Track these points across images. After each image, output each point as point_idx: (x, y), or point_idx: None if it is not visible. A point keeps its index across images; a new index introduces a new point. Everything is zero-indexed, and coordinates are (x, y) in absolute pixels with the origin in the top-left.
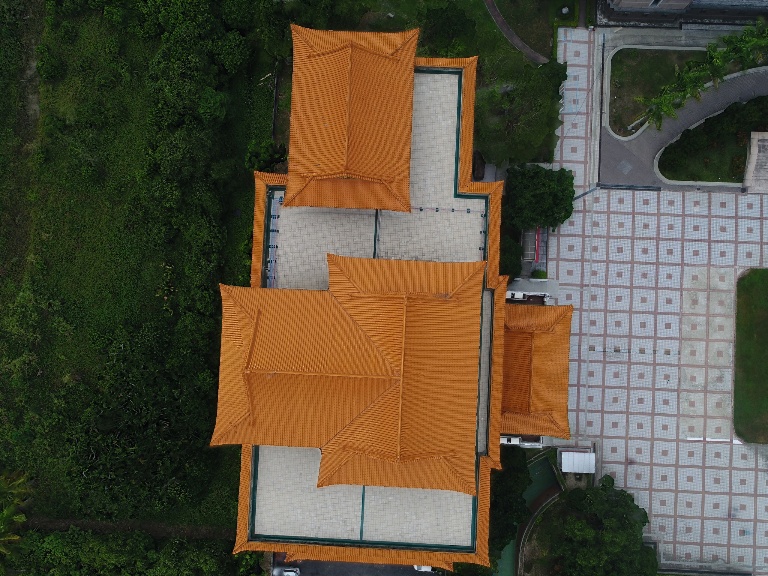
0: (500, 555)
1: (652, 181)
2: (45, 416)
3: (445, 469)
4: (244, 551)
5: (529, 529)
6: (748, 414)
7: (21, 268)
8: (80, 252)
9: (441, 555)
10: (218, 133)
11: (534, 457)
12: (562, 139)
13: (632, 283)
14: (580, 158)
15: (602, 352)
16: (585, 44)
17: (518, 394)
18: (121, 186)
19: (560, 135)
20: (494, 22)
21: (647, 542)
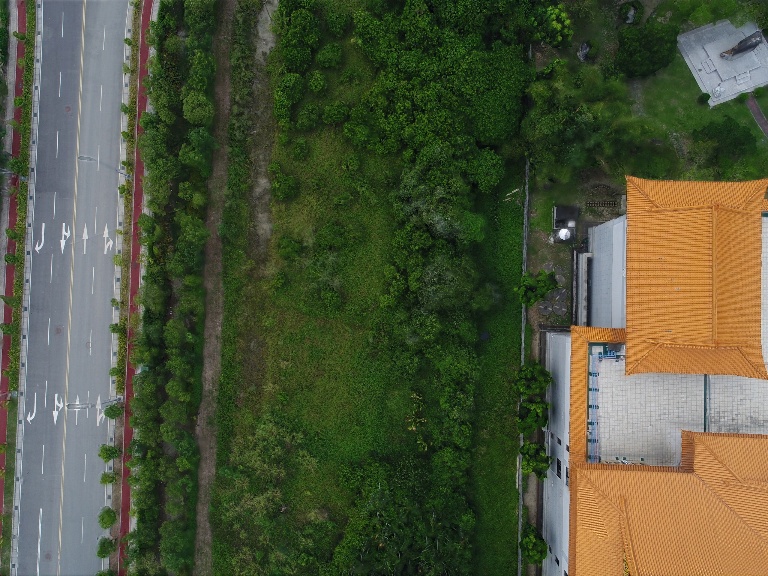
0: None
1: None
2: (292, 556)
3: None
4: None
5: None
6: None
7: (258, 397)
8: (321, 380)
9: None
10: (471, 256)
11: None
12: None
13: None
14: None
15: None
16: None
17: None
18: (362, 310)
19: None
20: (761, 131)
21: None
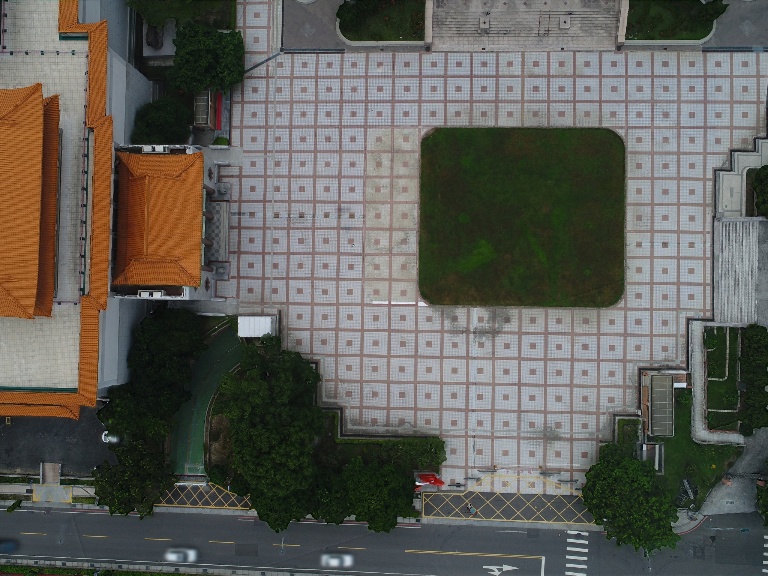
0: (177, 421)
1: (335, 43)
2: None
3: (0, 293)
4: None
5: (214, 398)
6: (433, 275)
7: None
8: None
9: (46, 397)
10: None
11: (218, 325)
12: (245, 5)
13: (316, 147)
14: (263, 23)
15: (286, 218)
16: None
17: (140, 240)
18: None
19: (243, 1)
20: None
21: (334, 408)
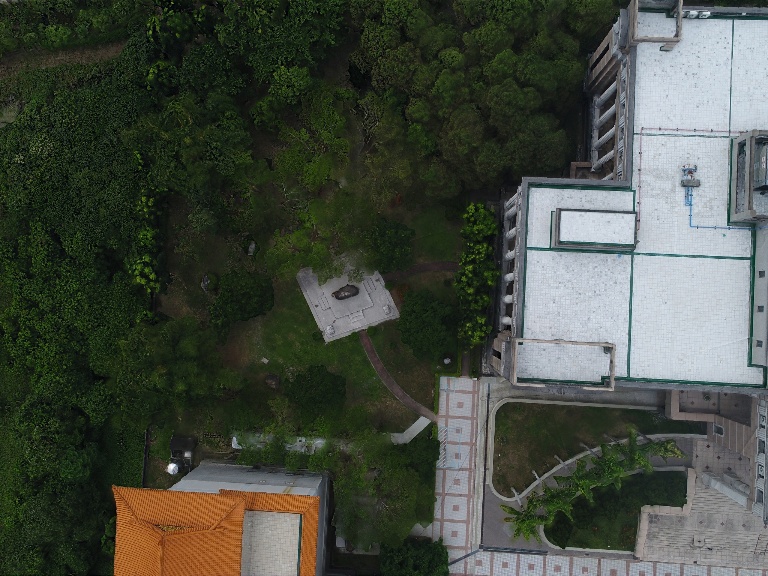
0: None
1: (538, 545)
2: None
3: None
4: None
5: None
6: None
7: None
8: None
9: None
10: (85, 486)
11: None
12: (443, 496)
13: None
14: (462, 517)
15: None
16: (469, 394)
17: None
18: None
19: (441, 492)
20: (373, 369)
21: None
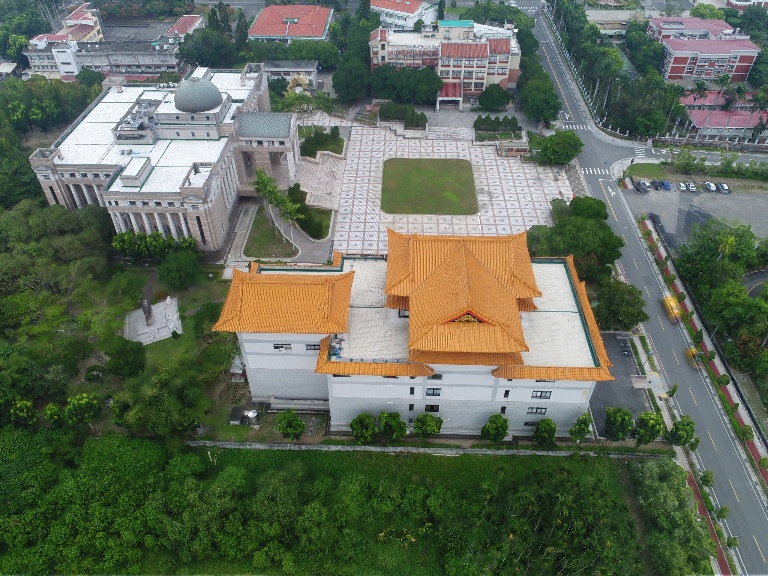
0: None
1: (328, 243)
2: None
3: None
4: (624, 422)
5: None
6: (462, 210)
7: None
8: None
9: (573, 274)
10: None
11: None
12: None
13: None
14: None
15: None
16: None
17: None
18: None
19: None
20: None
21: None
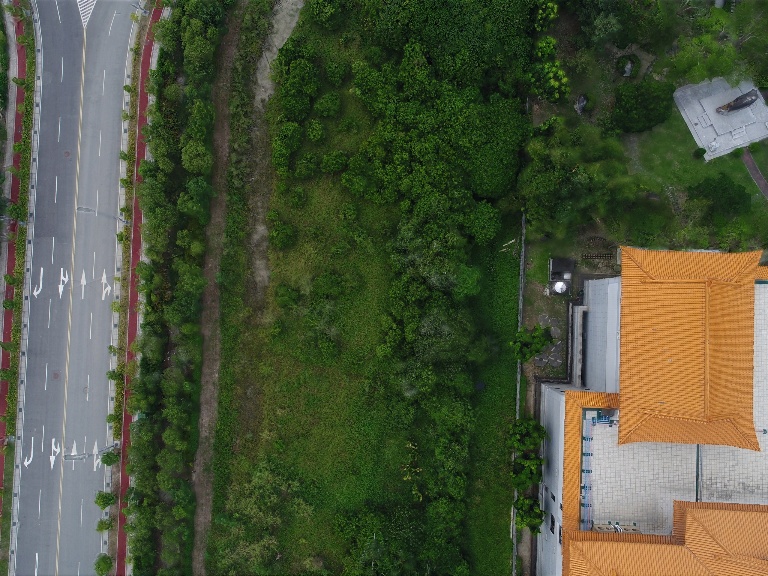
0: None
1: None
2: None
3: None
4: None
5: None
6: None
7: (254, 444)
8: (317, 428)
9: None
10: (467, 308)
11: None
12: None
13: None
14: None
15: None
16: None
17: None
18: (359, 359)
19: None
20: (756, 185)
21: None
